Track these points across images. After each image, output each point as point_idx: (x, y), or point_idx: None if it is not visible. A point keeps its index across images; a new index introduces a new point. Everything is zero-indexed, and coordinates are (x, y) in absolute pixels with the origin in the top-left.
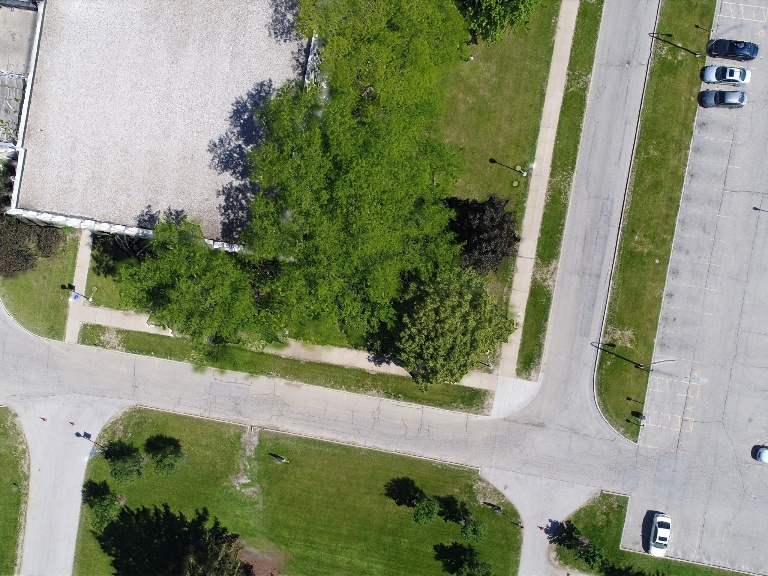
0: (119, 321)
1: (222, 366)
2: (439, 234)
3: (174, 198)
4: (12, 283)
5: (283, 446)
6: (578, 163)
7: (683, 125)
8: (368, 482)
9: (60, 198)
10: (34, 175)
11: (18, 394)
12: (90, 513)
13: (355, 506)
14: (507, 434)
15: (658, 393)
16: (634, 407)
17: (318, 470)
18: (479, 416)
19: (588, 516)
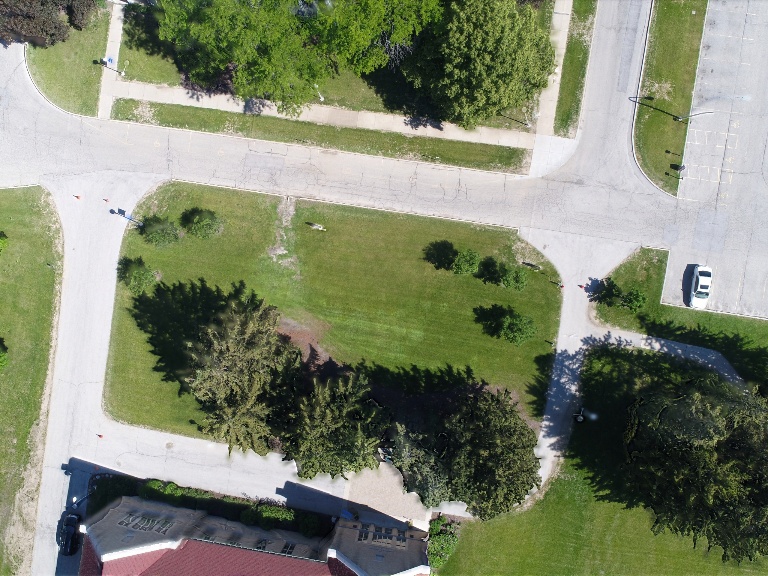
0: (152, 94)
1: (257, 136)
2: None
3: None
4: (43, 61)
5: (320, 214)
6: None
7: None
8: (406, 247)
9: None
10: None
11: (51, 173)
12: (126, 291)
13: (393, 272)
14: (545, 193)
15: (697, 145)
16: (673, 160)
17: (356, 237)
18: (517, 176)
19: (628, 272)
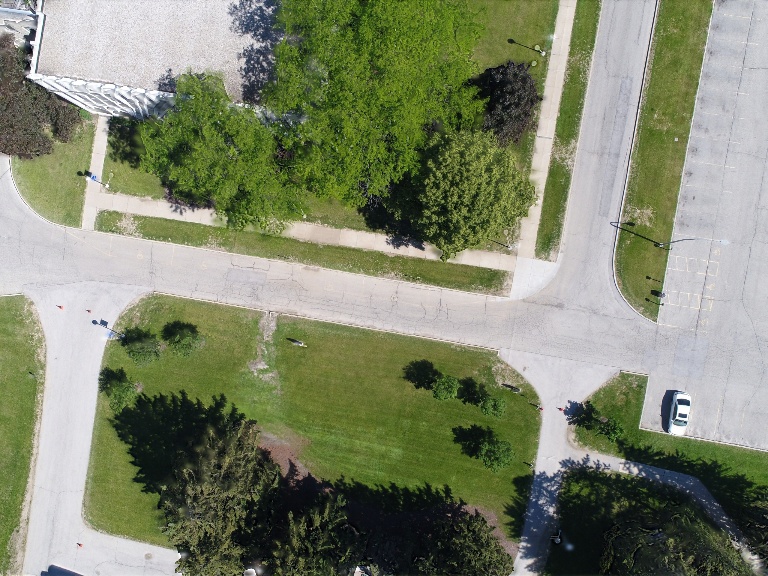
0: (136, 207)
1: (240, 251)
2: (463, 83)
3: (195, 61)
4: (28, 171)
5: (301, 331)
6: (597, 42)
7: (702, 2)
8: (386, 365)
9: (80, 63)
10: (53, 41)
11: (34, 282)
12: (107, 401)
13: (373, 390)
14: (526, 315)
15: (677, 272)
16: (653, 286)
17: (336, 354)
18: (498, 297)
19: (607, 396)
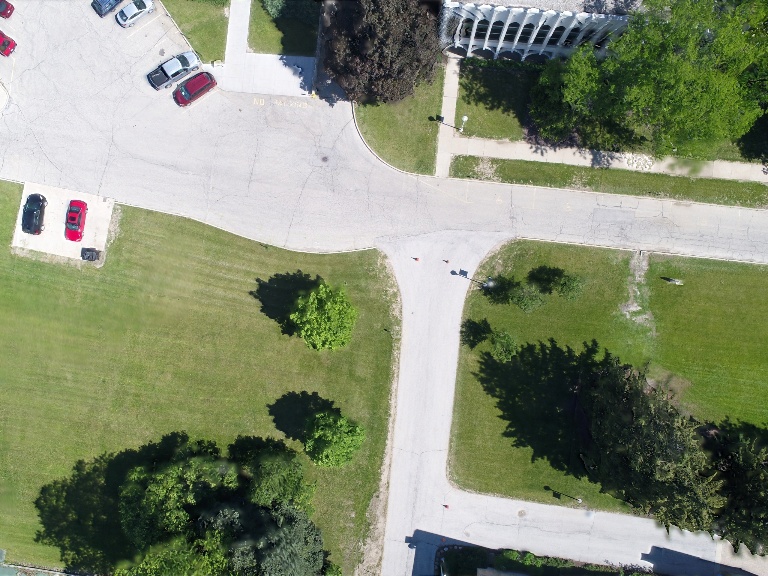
0: (493, 150)
1: (606, 190)
2: None
3: None
4: (374, 119)
5: (676, 269)
6: None
7: None
8: None
9: None
10: None
11: (386, 235)
12: (470, 354)
13: (756, 325)
14: None
15: None
16: None
17: (715, 291)
18: None
19: None
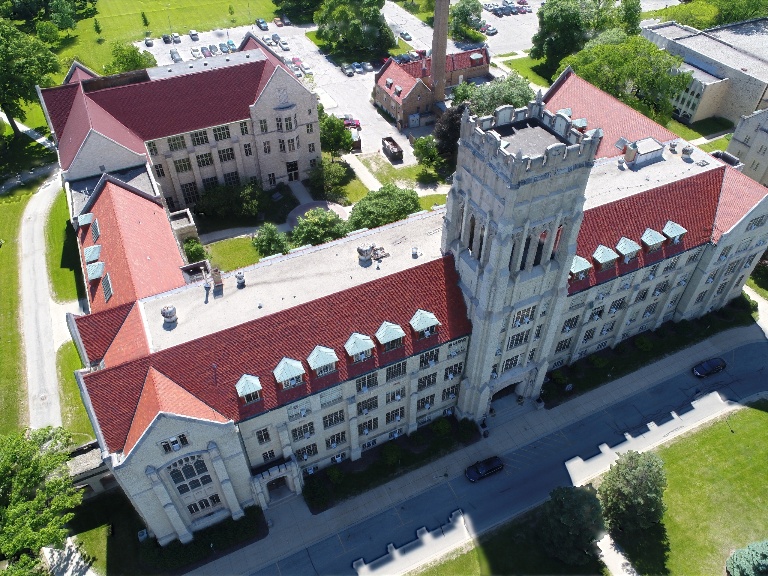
0: None
1: None
2: None
3: None
4: None
5: None
6: None
7: None
8: None
9: None
10: None
11: None
12: None
13: None
14: None
15: None
16: None
17: None
18: None
19: None
